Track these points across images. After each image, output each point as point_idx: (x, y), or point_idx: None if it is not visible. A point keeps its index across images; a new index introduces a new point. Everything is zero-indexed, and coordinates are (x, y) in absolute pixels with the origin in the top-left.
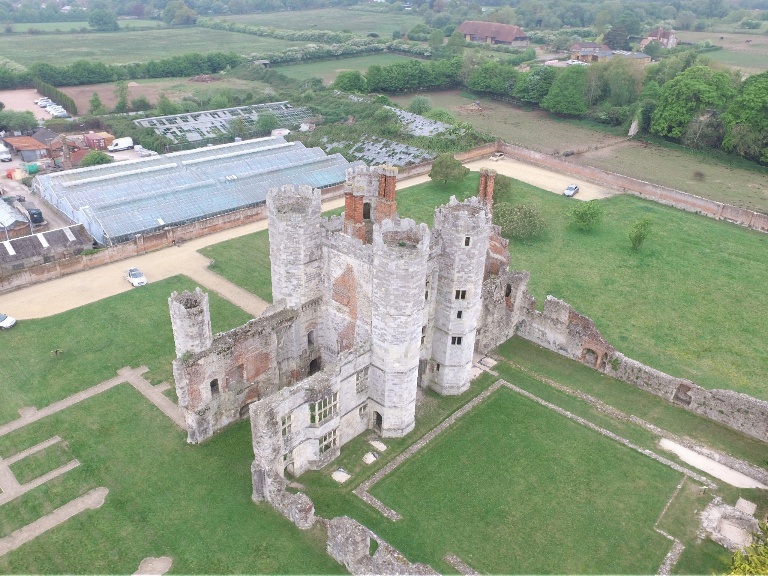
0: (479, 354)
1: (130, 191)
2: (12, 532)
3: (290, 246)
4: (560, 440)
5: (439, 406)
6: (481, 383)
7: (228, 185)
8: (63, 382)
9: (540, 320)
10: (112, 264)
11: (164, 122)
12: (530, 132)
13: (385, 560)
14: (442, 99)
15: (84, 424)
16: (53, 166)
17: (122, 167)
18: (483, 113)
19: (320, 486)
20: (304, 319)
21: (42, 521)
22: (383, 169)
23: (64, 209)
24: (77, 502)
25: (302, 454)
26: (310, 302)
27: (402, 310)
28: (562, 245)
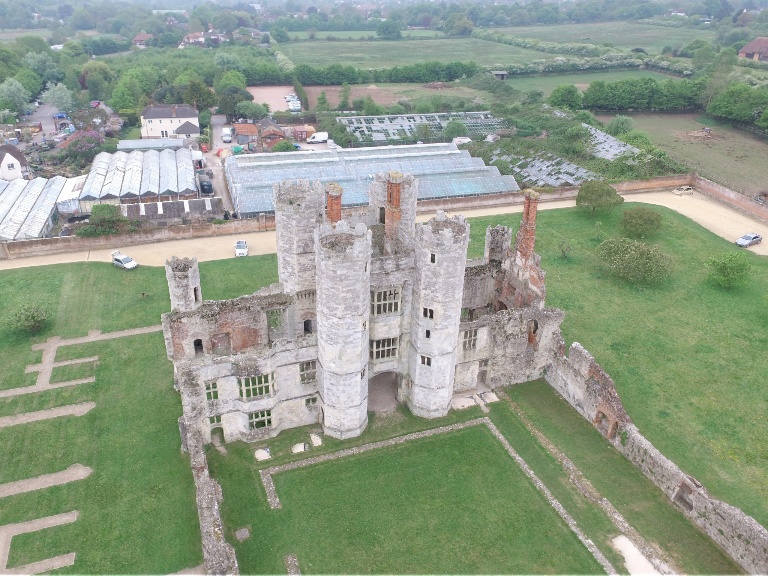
0: (486, 387)
1: (284, 177)
2: (18, 414)
3: (286, 235)
4: (497, 495)
5: (401, 423)
6: (462, 415)
7: (368, 182)
8: (131, 318)
9: (564, 368)
10: (235, 235)
11: (362, 121)
12: (752, 168)
13: (208, 530)
14: (669, 122)
15: (120, 353)
16: (246, 149)
17: (295, 156)
18: (708, 141)
19: (239, 456)
20: (300, 306)
21: (40, 413)
22: (389, 175)
23: (229, 185)
24: (70, 407)
25: (233, 423)
26: (307, 292)
27: (334, 311)
28: (681, 298)
